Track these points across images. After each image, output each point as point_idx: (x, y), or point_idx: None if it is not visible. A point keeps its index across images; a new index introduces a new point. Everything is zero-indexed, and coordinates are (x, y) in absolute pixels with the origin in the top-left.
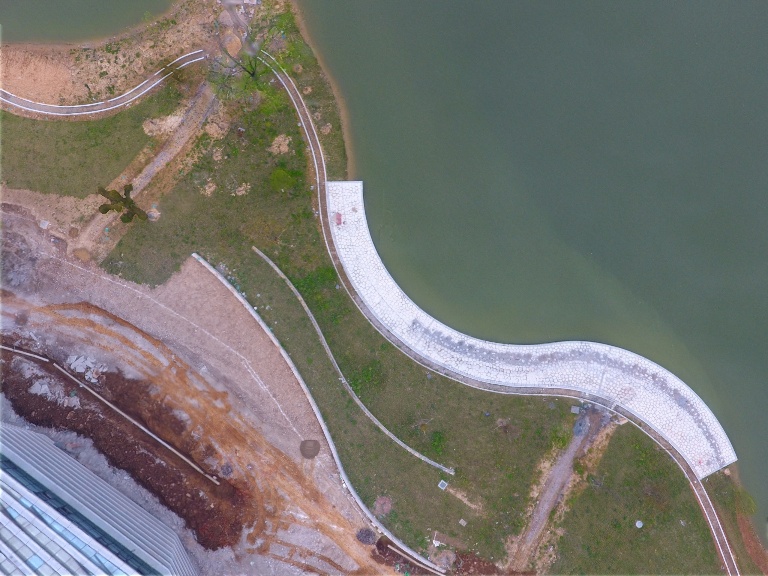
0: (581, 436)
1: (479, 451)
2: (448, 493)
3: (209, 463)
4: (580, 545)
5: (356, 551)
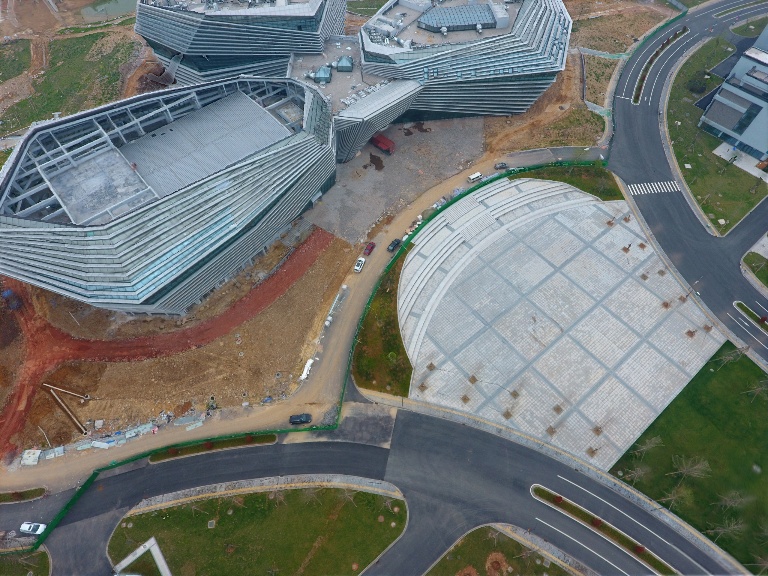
0: None
1: None
2: None
3: None
4: None
5: None
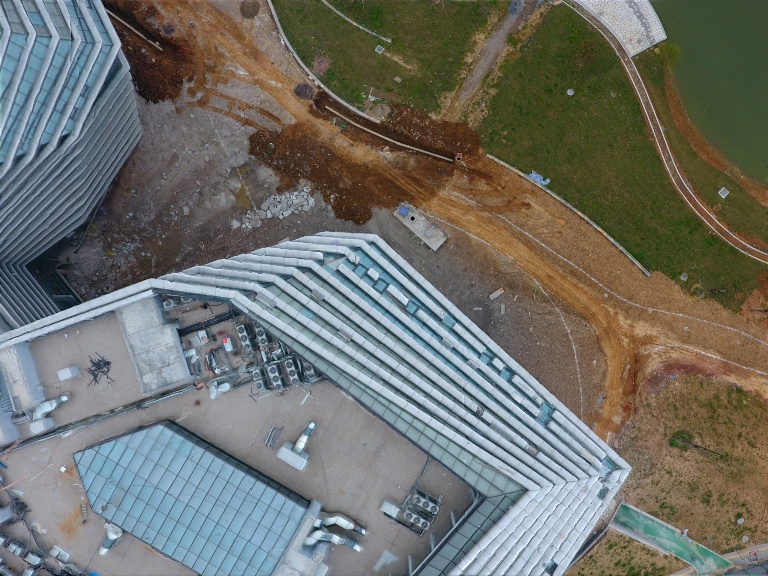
0: (516, 15)
1: (416, 23)
2: (384, 56)
3: (151, 22)
4: (512, 103)
5: (294, 106)
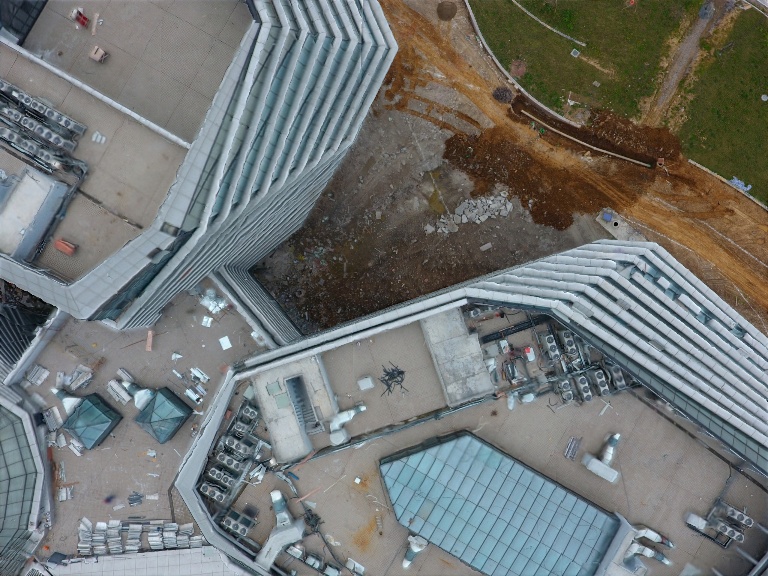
0: (706, 19)
1: (609, 27)
2: (581, 60)
3: None
4: (710, 109)
5: (492, 110)
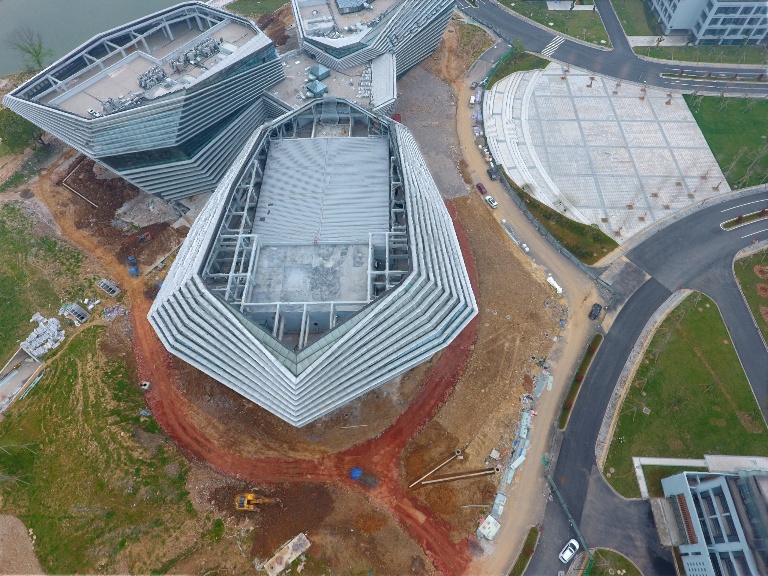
0: None
1: None
2: None
3: None
4: None
5: None
